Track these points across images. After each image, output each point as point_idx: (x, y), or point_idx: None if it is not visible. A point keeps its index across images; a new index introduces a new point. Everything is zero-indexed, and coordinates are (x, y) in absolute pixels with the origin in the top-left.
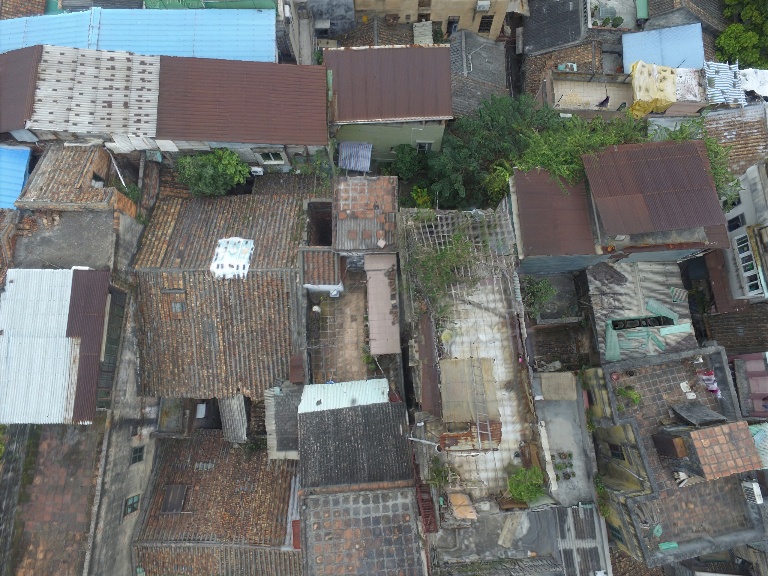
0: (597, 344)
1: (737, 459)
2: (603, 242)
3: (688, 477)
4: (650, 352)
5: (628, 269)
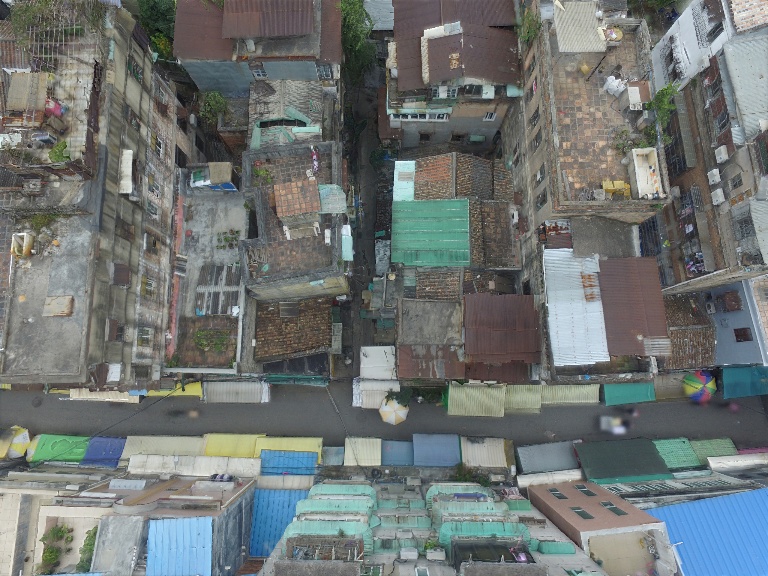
0: (246, 138)
1: (302, 204)
2: (241, 53)
3: (288, 229)
4: (279, 143)
5: (278, 85)
